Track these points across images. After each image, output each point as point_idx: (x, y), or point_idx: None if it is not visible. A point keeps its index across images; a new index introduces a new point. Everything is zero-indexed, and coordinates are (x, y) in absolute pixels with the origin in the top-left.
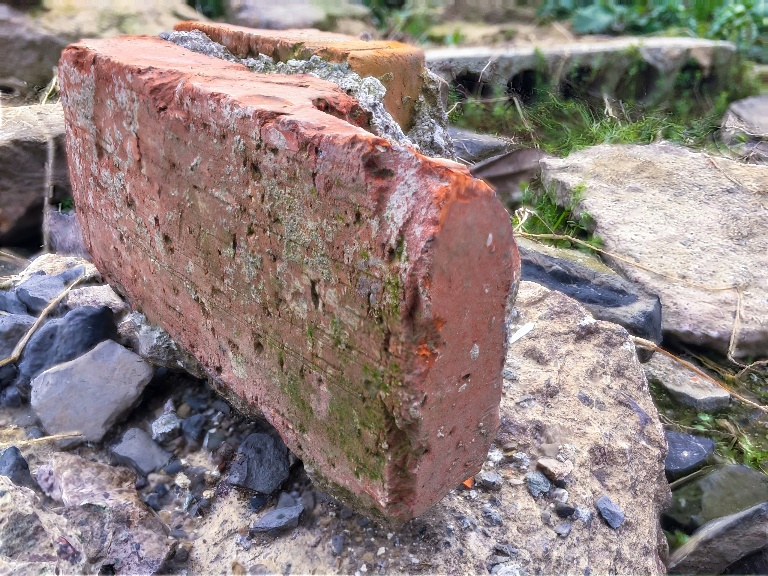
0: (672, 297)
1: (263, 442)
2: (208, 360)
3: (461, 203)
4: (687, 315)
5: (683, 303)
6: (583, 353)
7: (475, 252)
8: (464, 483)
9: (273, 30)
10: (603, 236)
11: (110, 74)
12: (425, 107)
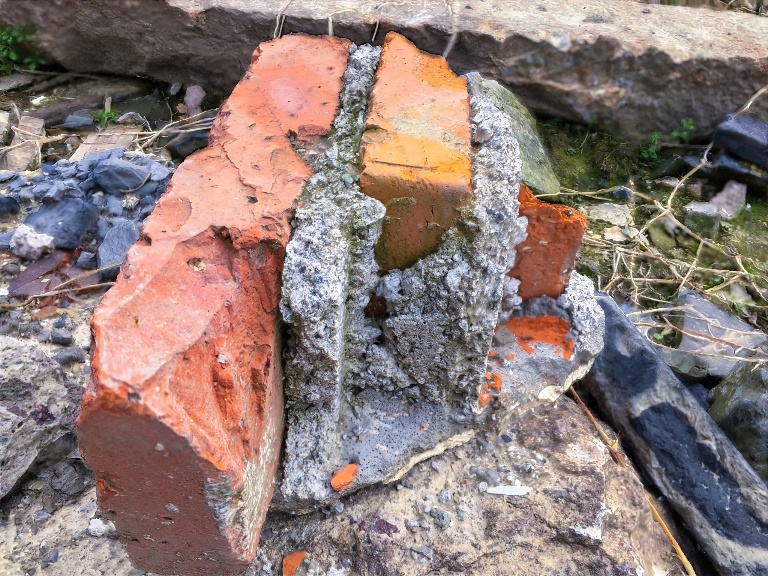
0: None
1: None
2: None
3: (106, 414)
4: None
5: None
6: (544, 557)
7: (139, 449)
8: (283, 572)
9: (422, 82)
10: None
11: None
12: (455, 240)
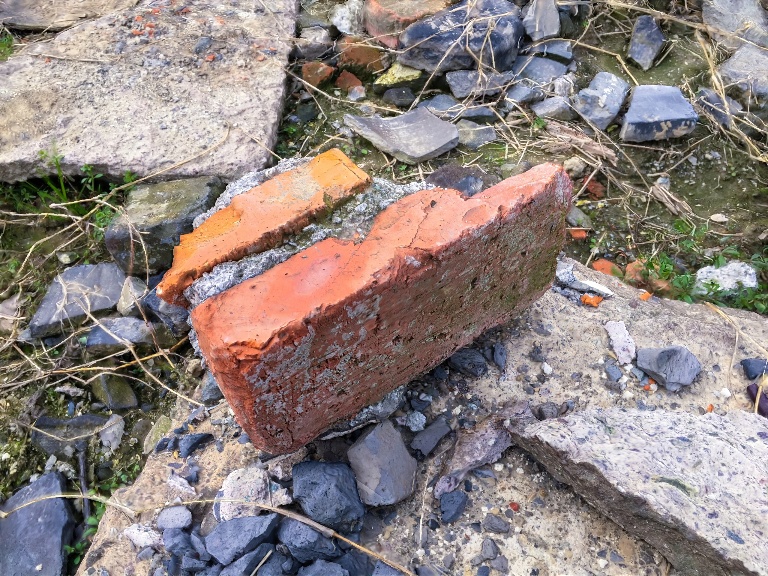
0: (224, 162)
1: (458, 357)
2: (443, 355)
3: None
4: (246, 163)
5: (234, 159)
6: None
7: None
8: None
9: (244, 218)
10: (126, 168)
11: (341, 310)
12: None
